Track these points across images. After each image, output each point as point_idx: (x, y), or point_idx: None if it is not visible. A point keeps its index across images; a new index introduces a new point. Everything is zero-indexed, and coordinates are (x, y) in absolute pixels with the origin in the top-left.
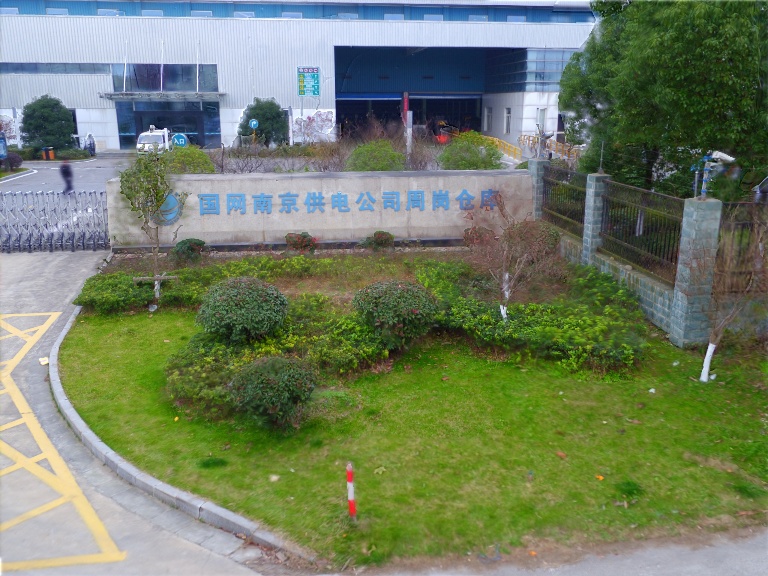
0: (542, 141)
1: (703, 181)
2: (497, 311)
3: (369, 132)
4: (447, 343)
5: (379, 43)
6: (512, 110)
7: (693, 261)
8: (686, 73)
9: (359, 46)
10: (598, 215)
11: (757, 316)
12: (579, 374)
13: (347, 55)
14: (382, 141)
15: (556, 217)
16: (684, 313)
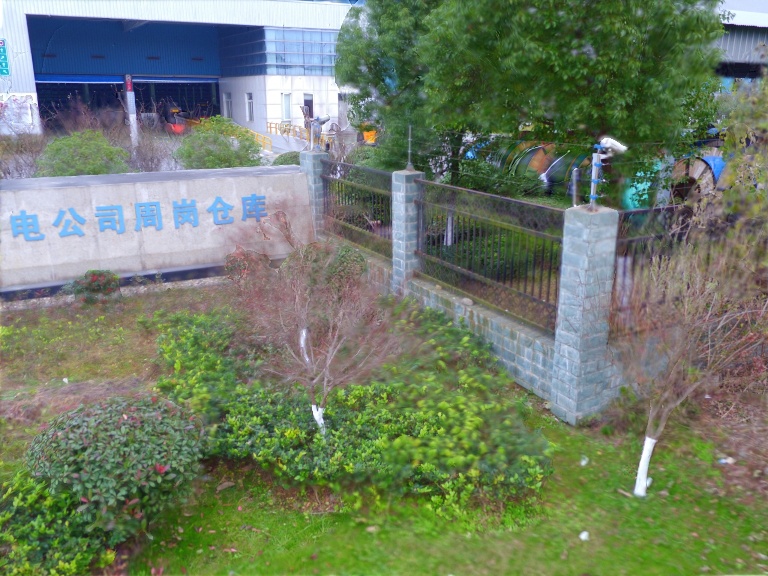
0: (316, 128)
1: (592, 182)
2: (305, 411)
3: (74, 120)
4: (227, 485)
5: (86, 13)
6: (254, 95)
7: (586, 301)
8: (560, 18)
9: (60, 16)
10: (412, 227)
11: (655, 363)
12: (464, 521)
13: (45, 26)
14: (90, 131)
15: (346, 228)
16: (576, 376)
